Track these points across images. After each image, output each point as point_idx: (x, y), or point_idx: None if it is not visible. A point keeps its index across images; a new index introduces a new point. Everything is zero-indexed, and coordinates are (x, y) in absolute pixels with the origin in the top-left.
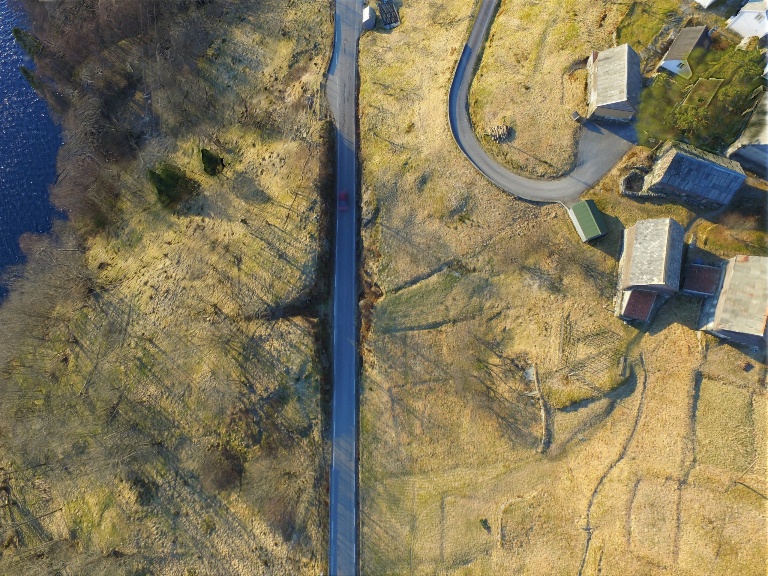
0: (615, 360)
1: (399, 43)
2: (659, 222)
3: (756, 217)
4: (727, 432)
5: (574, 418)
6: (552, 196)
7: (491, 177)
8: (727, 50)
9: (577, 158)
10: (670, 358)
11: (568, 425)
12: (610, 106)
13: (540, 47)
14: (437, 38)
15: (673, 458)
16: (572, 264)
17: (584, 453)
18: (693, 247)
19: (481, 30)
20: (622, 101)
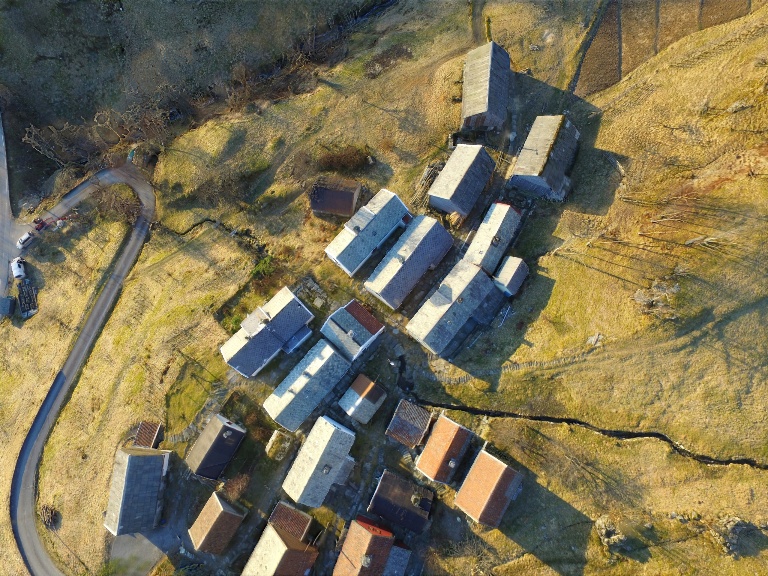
0: None
1: (24, 344)
2: None
3: None
4: None
5: None
6: None
7: (35, 573)
8: (265, 438)
9: (108, 566)
10: None
11: None
12: None
13: (112, 395)
14: (50, 347)
15: None
16: None
17: None
18: None
19: (83, 348)
20: None
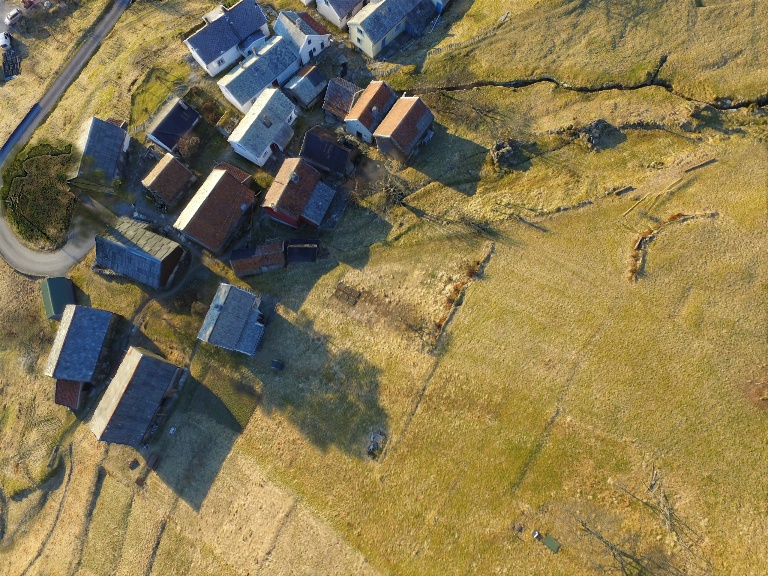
0: (49, 449)
1: (5, 97)
2: (71, 309)
3: (179, 303)
4: (106, 534)
5: (19, 508)
6: (44, 270)
7: None
8: (217, 121)
9: (68, 231)
10: (88, 450)
11: (15, 515)
12: (76, 181)
13: (83, 110)
14: (29, 94)
15: (66, 559)
16: (46, 343)
17: (22, 546)
18: (135, 331)
19: (59, 88)
20: (74, 178)
